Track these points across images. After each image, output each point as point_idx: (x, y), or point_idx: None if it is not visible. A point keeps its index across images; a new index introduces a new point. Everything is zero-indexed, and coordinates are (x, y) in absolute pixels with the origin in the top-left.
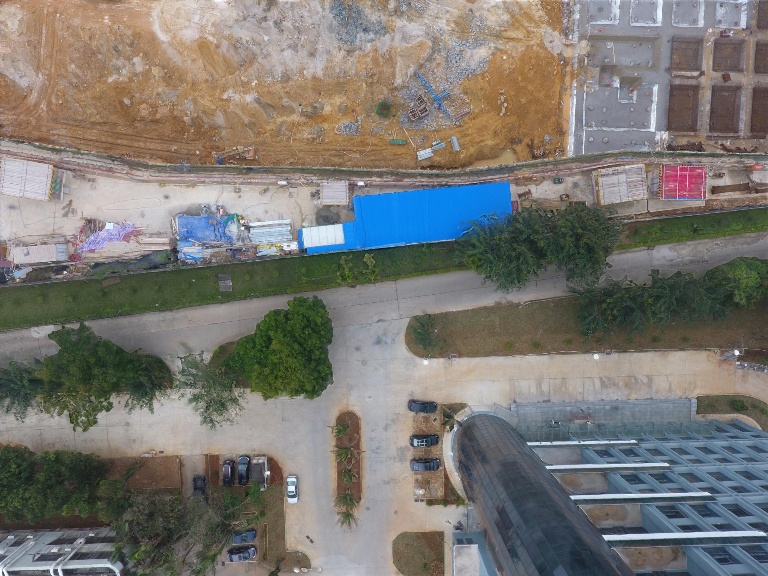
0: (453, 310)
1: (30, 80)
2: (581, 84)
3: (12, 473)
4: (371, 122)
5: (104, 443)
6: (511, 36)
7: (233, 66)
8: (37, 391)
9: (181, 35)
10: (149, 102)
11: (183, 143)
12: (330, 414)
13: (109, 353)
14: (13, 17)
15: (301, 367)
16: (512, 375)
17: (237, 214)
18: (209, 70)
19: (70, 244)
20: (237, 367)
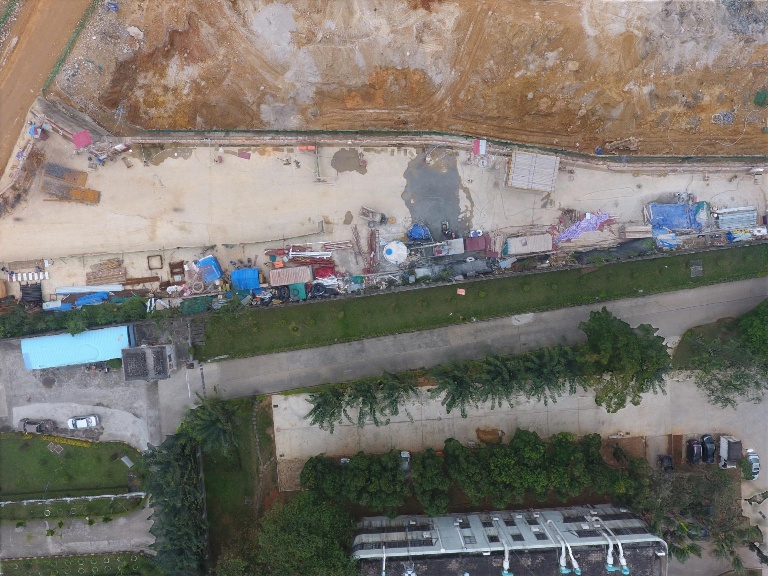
0: None
1: (443, 77)
2: None
3: (541, 454)
4: (746, 111)
5: (575, 426)
6: None
7: (637, 59)
8: (564, 375)
9: (608, 29)
10: (550, 96)
11: (563, 136)
12: None
13: None
14: (451, 15)
15: None
16: None
17: (706, 202)
18: (620, 63)
19: None
20: (754, 348)
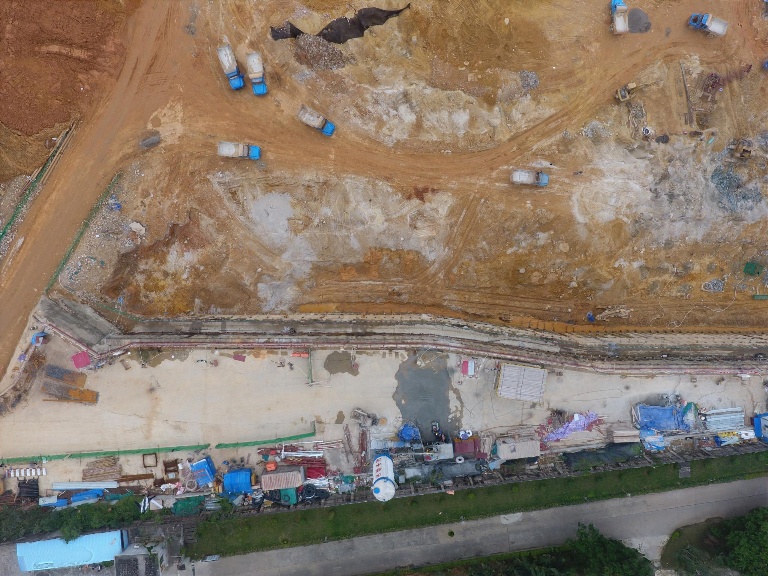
0: None
1: (437, 254)
2: None
3: None
4: (736, 279)
5: None
6: None
7: (627, 237)
8: None
9: (598, 217)
10: (542, 270)
11: (555, 301)
12: None
13: None
14: (444, 204)
15: None
16: None
17: (693, 403)
18: (610, 244)
19: (536, 434)
20: (741, 568)
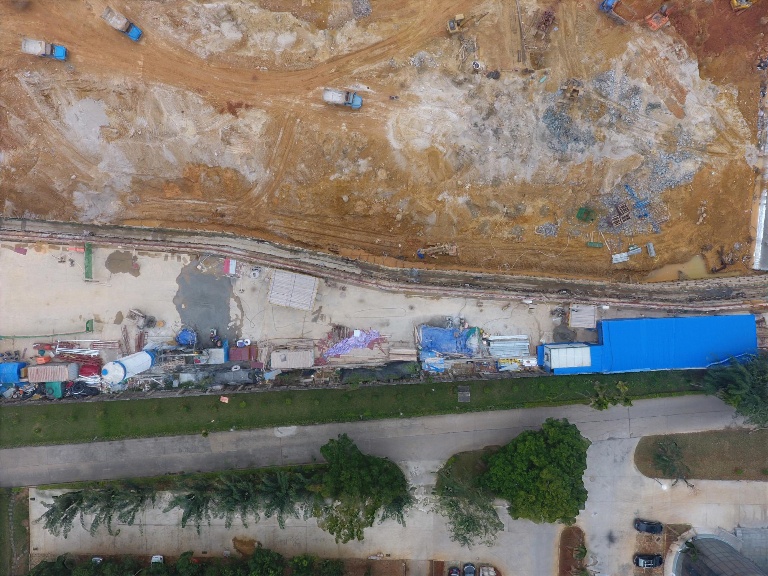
0: (683, 432)
1: (258, 175)
2: None
3: None
4: (570, 225)
5: (334, 543)
6: (716, 151)
7: (451, 170)
8: (299, 500)
9: (413, 144)
10: (366, 200)
11: (386, 236)
12: (555, 528)
13: (380, 471)
14: (258, 121)
15: (568, 497)
16: (737, 499)
17: (478, 327)
18: (431, 175)
19: (317, 348)
20: (493, 488)
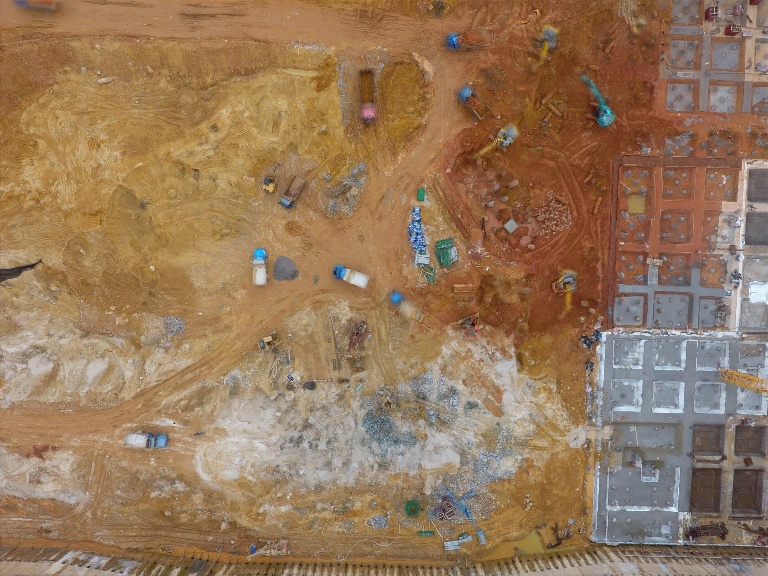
0: None
1: (78, 498)
2: (604, 467)
3: None
4: (400, 516)
5: None
6: (537, 445)
7: (269, 484)
8: None
9: (222, 475)
10: (188, 513)
11: (219, 533)
12: None
13: None
14: (65, 461)
15: None
16: None
17: None
18: (247, 494)
19: None
20: None
